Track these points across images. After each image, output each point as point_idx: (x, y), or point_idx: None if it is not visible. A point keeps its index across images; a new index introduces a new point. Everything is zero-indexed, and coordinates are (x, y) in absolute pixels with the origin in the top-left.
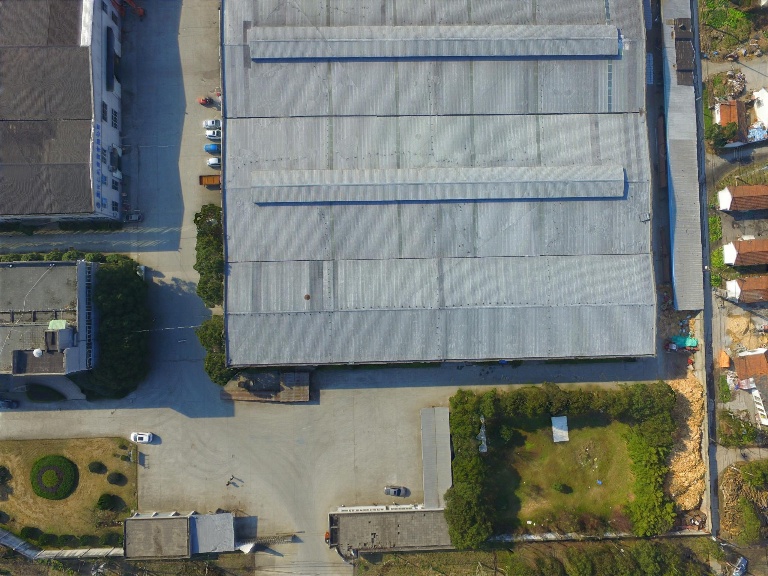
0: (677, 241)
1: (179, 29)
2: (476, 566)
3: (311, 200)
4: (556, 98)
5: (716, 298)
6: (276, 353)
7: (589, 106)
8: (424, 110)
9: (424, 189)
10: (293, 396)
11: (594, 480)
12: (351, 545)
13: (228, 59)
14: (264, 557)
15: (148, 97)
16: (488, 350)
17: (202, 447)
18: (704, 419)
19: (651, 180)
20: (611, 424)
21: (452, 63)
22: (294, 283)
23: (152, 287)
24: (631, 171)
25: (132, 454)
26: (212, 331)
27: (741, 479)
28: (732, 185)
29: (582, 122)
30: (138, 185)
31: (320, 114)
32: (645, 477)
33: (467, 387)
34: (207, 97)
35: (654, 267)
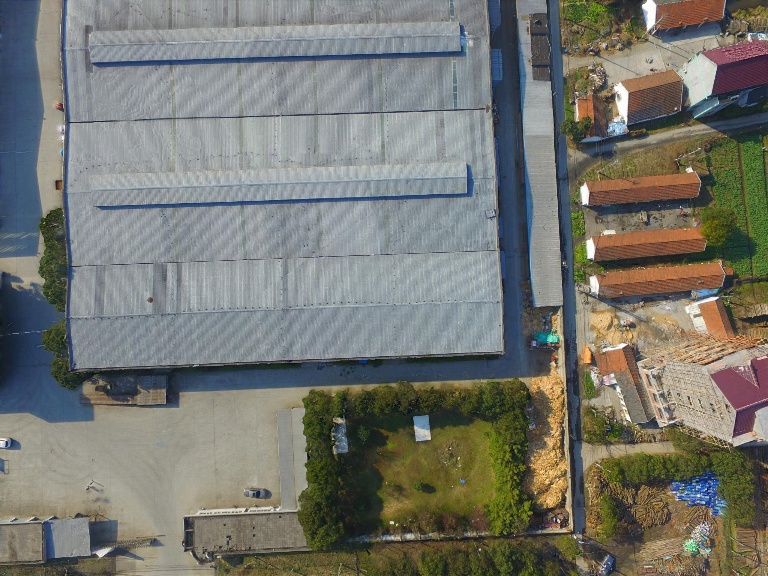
0: (534, 237)
1: (37, 35)
2: (338, 567)
3: (152, 203)
4: (401, 96)
5: (580, 294)
6: (120, 356)
7: (434, 103)
8: (268, 111)
9: (265, 190)
10: (150, 399)
11: (457, 479)
12: (206, 548)
13: (70, 64)
14: (125, 561)
15: (6, 103)
16: (334, 350)
17: (61, 452)
18: (565, 416)
19: (495, 176)
20: (474, 422)
21: (295, 63)
22: (137, 286)
23: (10, 292)
24: (476, 168)
25: None
26: (54, 335)
27: (606, 476)
28: (594, 180)
29: (427, 119)
30: None
31: (163, 117)
32: (502, 475)
33: (327, 387)
34: (62, 102)
35: (516, 264)
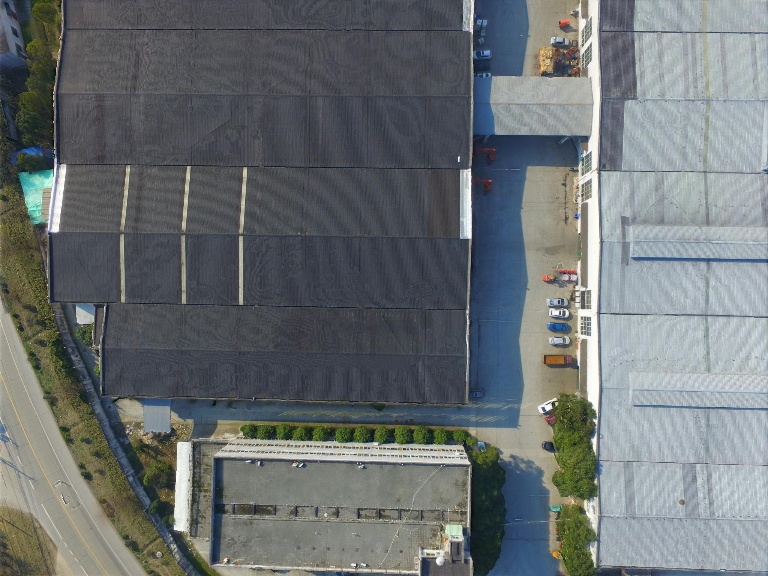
0: None
1: (522, 203)
2: None
3: (692, 405)
4: None
5: None
6: (647, 556)
7: None
8: None
9: None
10: None
11: None
12: None
13: (606, 255)
14: None
15: (489, 271)
16: None
17: None
18: None
19: None
20: None
21: None
22: (668, 486)
23: None
24: None
25: None
26: (587, 533)
27: None
28: None
29: None
30: (478, 359)
31: (695, 313)
32: None
33: None
34: (554, 276)
35: None
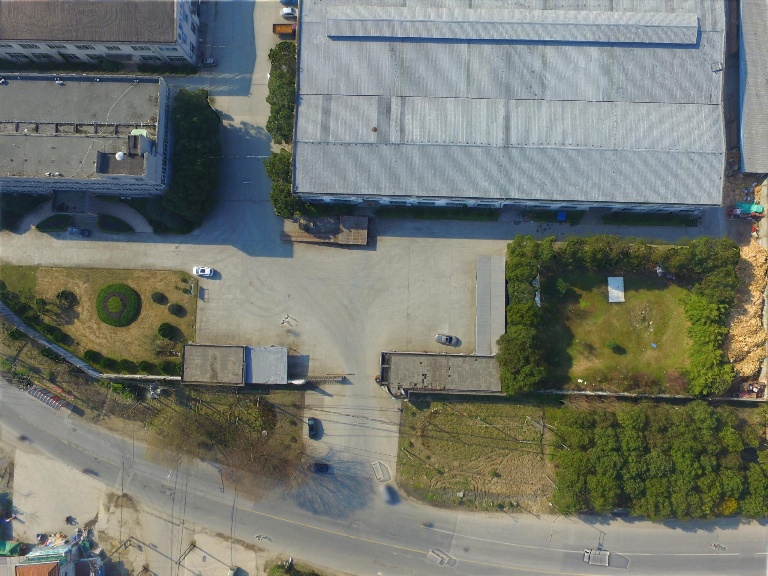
0: (747, 103)
1: None
2: (524, 420)
3: (384, 35)
4: None
5: None
6: (341, 183)
7: None
8: None
9: (495, 28)
10: (351, 239)
11: (649, 343)
12: (402, 384)
13: None
14: (314, 396)
15: None
16: (551, 191)
17: (260, 285)
18: (767, 285)
19: (725, 29)
20: (669, 288)
21: None
22: (362, 116)
23: (221, 129)
24: (705, 20)
25: (193, 287)
26: (281, 157)
27: None
28: None
29: None
30: (214, 33)
31: None
32: (704, 335)
33: None
34: None
35: None
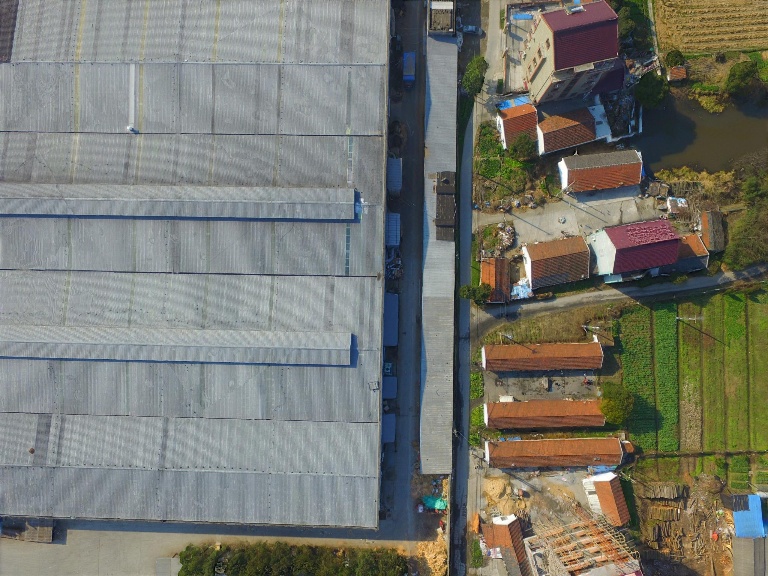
0: (426, 402)
1: None
2: None
3: (39, 356)
4: (293, 260)
5: (474, 458)
6: (0, 504)
7: (326, 268)
8: (160, 267)
9: (149, 350)
10: (37, 536)
11: None
12: None
13: None
14: None
15: None
16: (208, 513)
17: None
18: None
19: (380, 349)
20: None
21: (189, 222)
22: (21, 436)
23: None
24: (362, 338)
25: None
26: None
27: None
28: (496, 341)
29: (318, 285)
30: None
31: (59, 268)
32: None
33: (212, 536)
34: None
35: (410, 423)
